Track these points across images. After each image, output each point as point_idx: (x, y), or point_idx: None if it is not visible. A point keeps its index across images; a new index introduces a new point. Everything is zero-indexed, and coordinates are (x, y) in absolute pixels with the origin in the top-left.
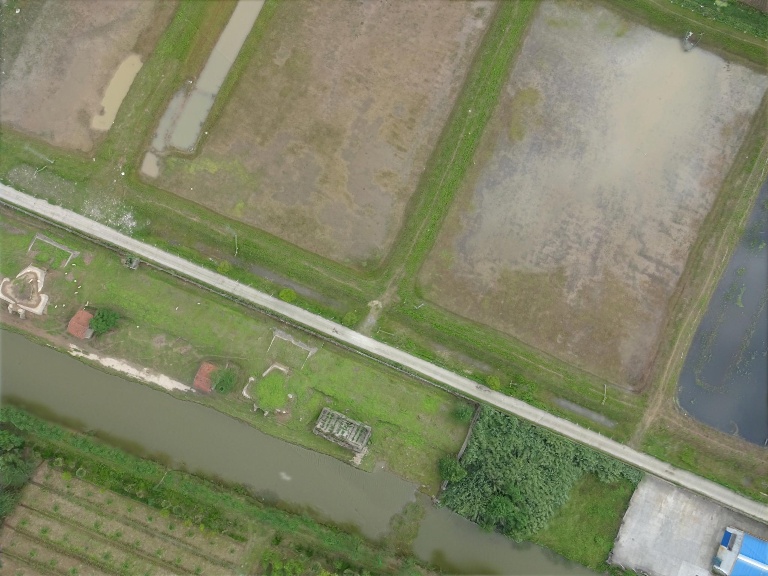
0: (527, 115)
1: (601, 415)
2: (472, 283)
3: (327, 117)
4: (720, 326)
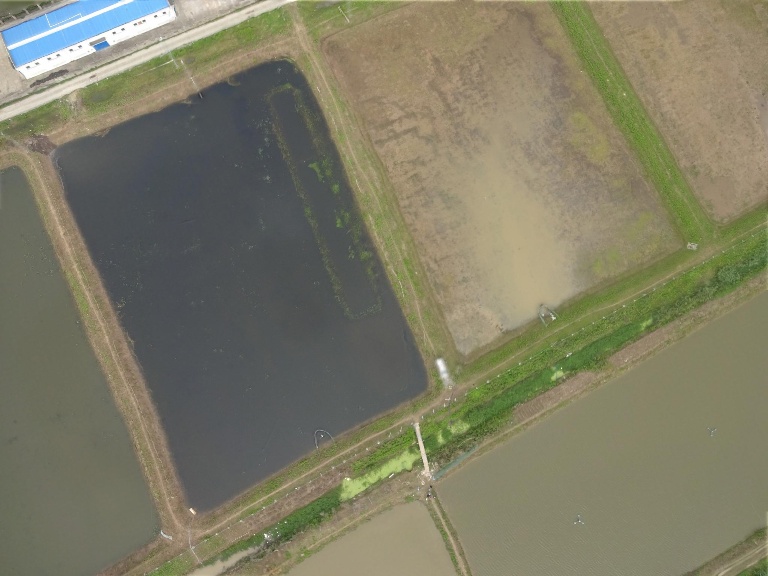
0: (588, 137)
1: (331, 5)
2: (497, 1)
3: (693, 6)
4: (311, 136)
